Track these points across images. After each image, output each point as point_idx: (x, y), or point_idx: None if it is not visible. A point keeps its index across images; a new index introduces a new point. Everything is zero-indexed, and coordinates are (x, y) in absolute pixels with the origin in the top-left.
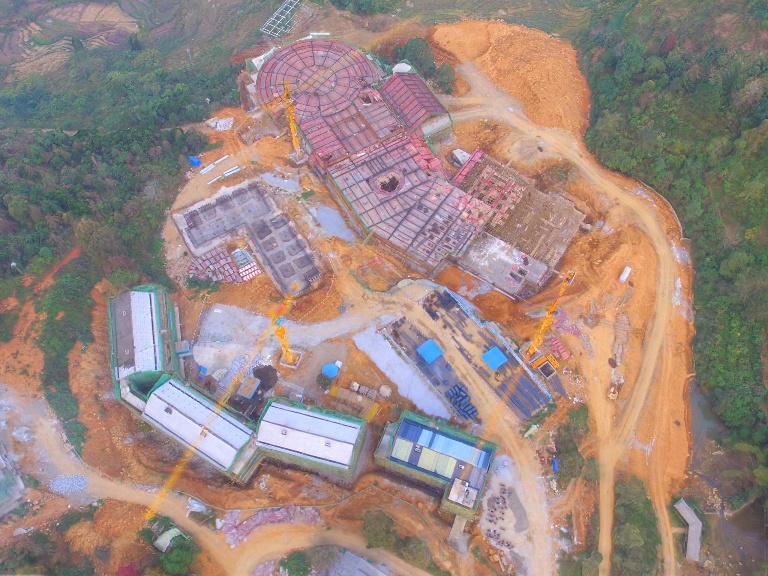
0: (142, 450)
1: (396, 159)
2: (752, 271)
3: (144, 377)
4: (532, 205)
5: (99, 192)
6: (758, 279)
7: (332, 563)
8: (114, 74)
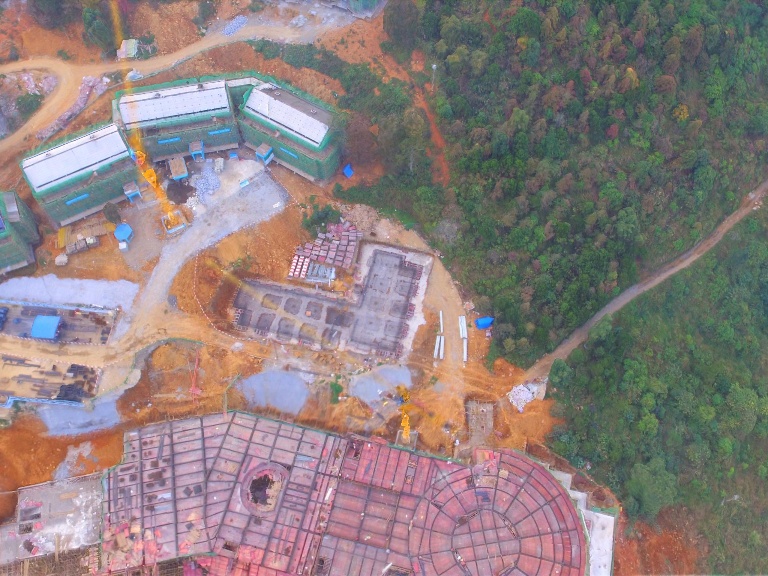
0: None
1: (283, 528)
2: None
3: None
4: None
5: None
6: None
7: None
8: (767, 403)
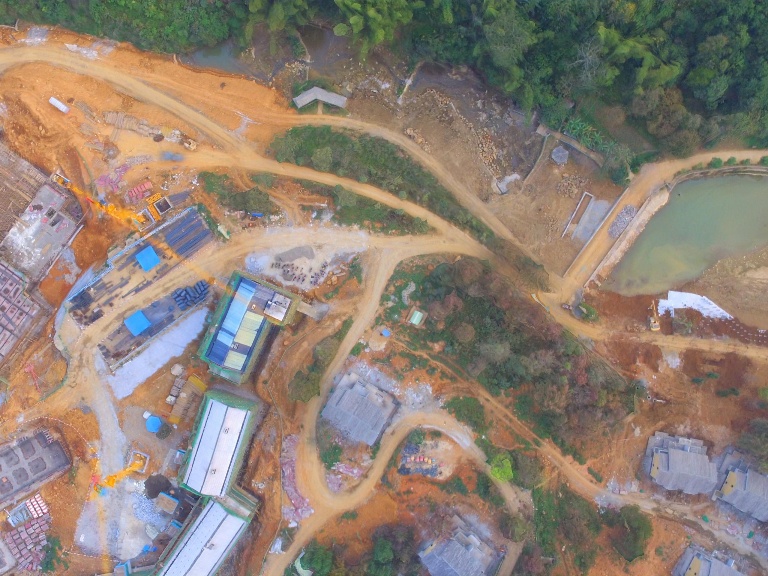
0: None
1: None
2: None
3: None
4: None
5: None
6: None
7: None
8: None
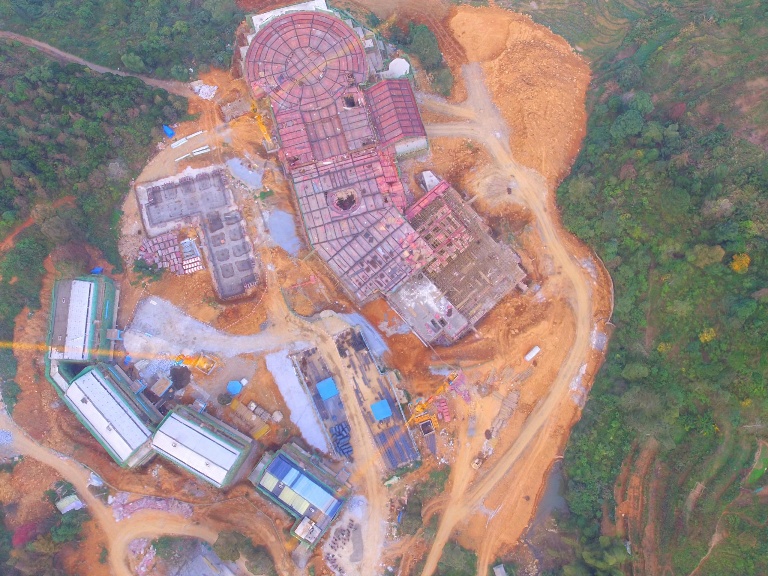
0: (65, 416)
1: (359, 176)
2: (642, 390)
3: (72, 361)
4: (478, 253)
5: (71, 151)
6: (642, 401)
7: (187, 560)
8: None
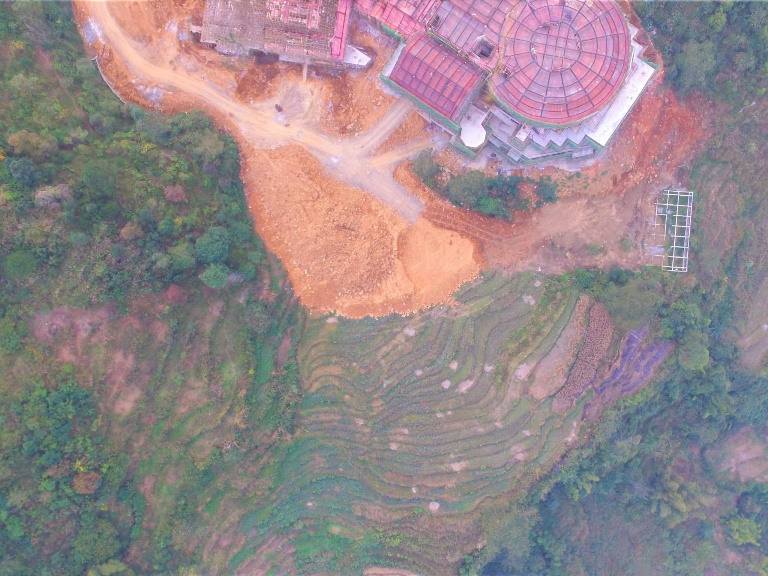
0: None
1: None
2: None
3: None
4: None
5: None
6: None
7: None
8: None
